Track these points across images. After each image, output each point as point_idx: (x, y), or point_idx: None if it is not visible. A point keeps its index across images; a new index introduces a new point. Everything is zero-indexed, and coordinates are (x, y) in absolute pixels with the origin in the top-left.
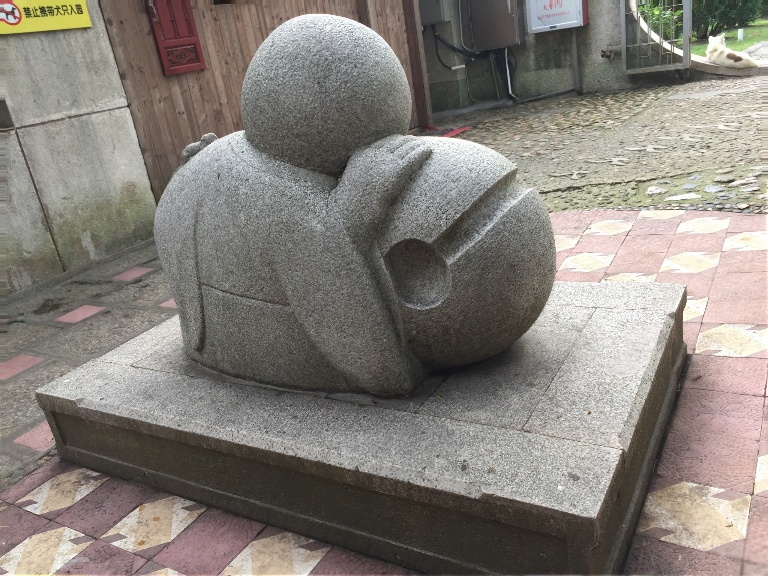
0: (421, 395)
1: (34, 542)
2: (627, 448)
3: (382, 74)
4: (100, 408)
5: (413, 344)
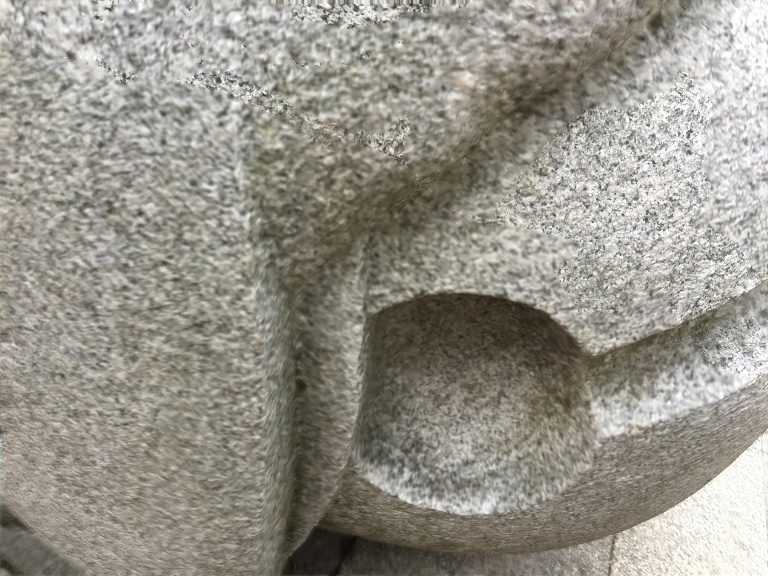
0: None
1: None
2: None
3: None
4: None
5: (321, 523)
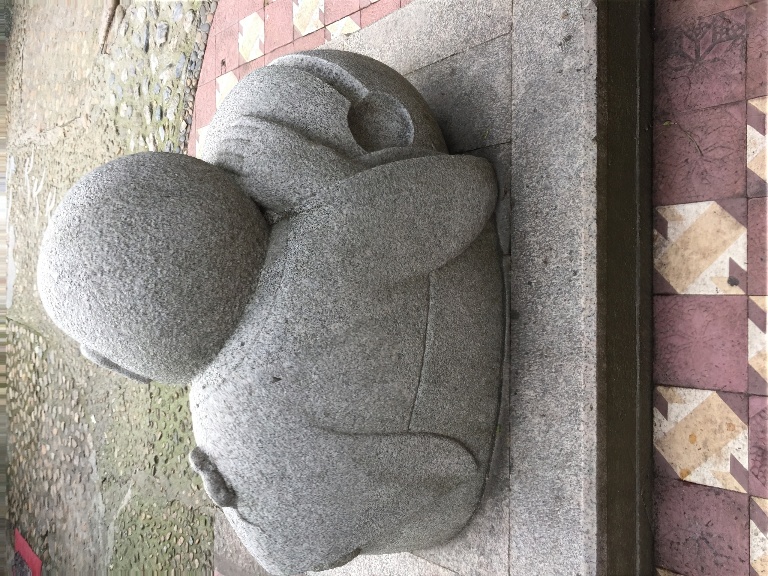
0: (486, 157)
1: None
2: None
3: None
4: (592, 569)
5: None
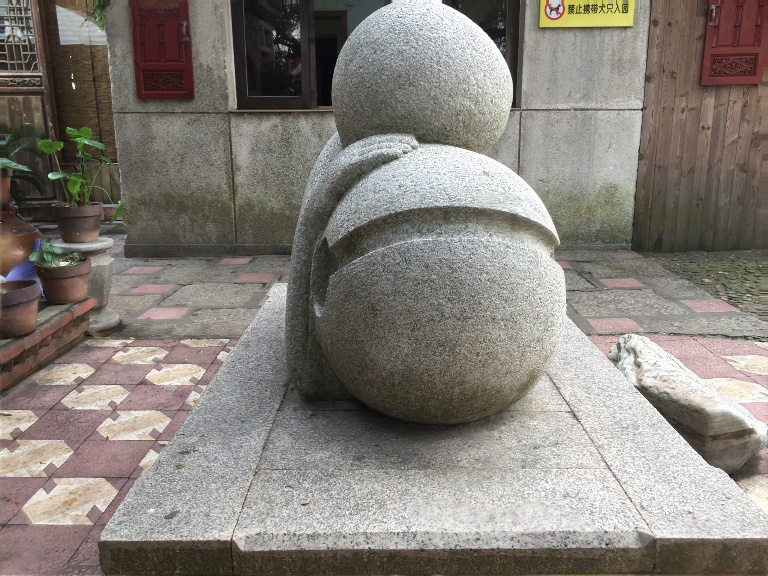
0: (313, 406)
1: (188, 367)
2: (250, 549)
3: (400, 65)
4: None
5: None
